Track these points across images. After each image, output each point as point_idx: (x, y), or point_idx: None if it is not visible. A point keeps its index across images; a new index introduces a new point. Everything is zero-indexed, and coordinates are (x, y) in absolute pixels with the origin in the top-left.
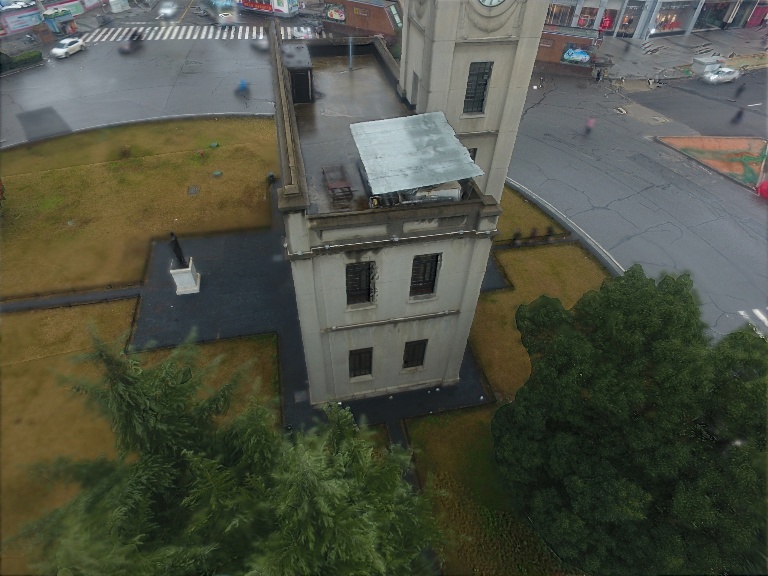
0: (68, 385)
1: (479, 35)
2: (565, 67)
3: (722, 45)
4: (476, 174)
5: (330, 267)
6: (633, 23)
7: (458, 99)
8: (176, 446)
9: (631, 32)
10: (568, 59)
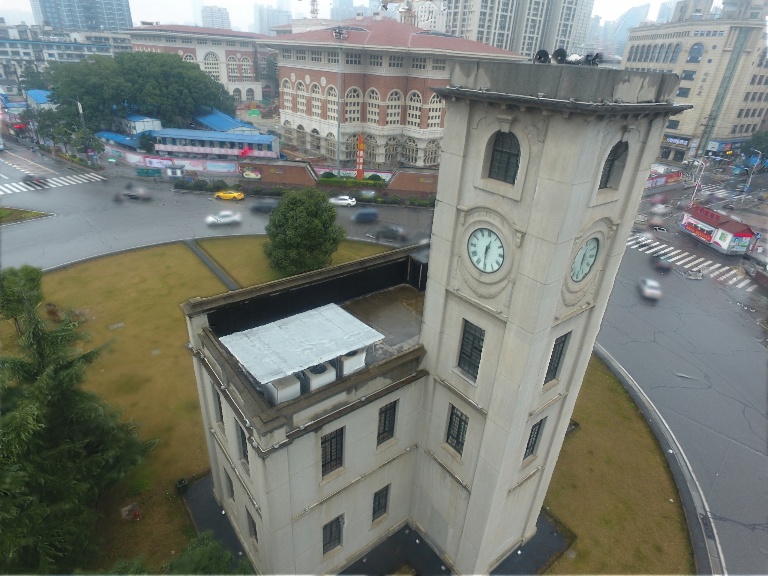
0: None
1: (471, 294)
2: None
3: None
4: (261, 379)
5: (206, 375)
6: None
7: (451, 348)
8: (37, 371)
9: None
10: None
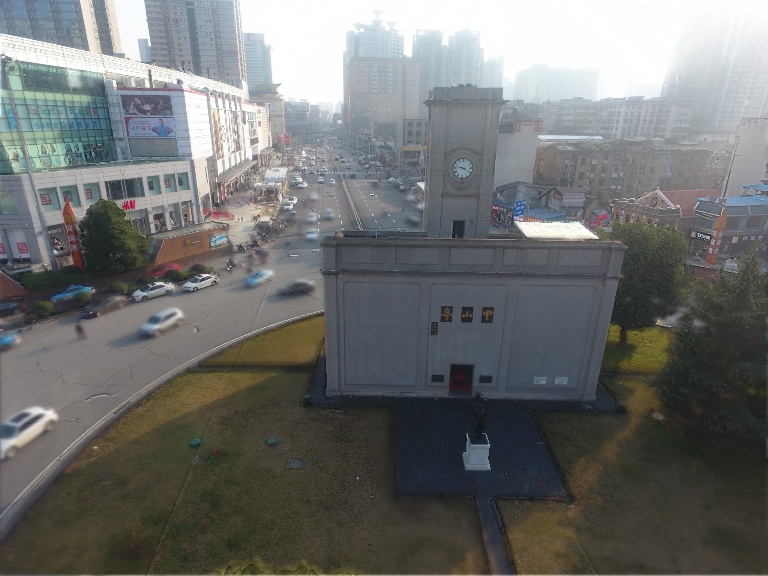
0: (624, 539)
1: None
2: (215, 251)
3: (239, 214)
4: None
5: None
6: (187, 216)
7: None
8: None
9: (191, 222)
10: (214, 245)
